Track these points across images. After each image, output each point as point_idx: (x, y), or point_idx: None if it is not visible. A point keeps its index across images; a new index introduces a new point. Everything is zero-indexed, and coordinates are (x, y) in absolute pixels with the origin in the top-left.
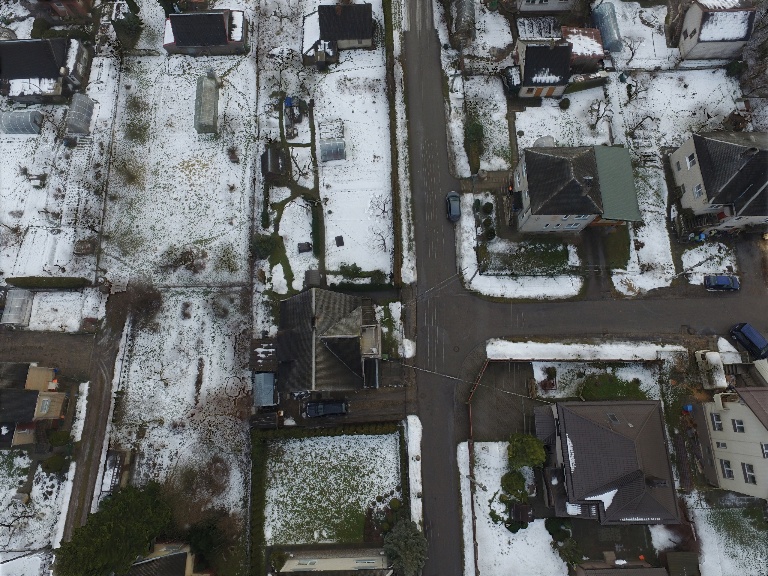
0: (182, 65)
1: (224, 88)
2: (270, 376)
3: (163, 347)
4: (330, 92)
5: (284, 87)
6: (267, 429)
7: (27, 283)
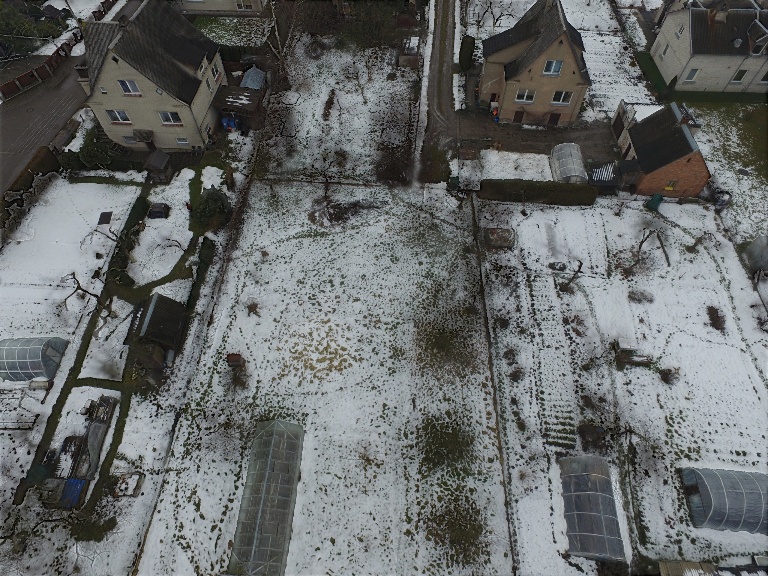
0: None
1: (224, 568)
2: None
3: None
4: None
5: (68, 555)
6: (253, 54)
7: (562, 183)
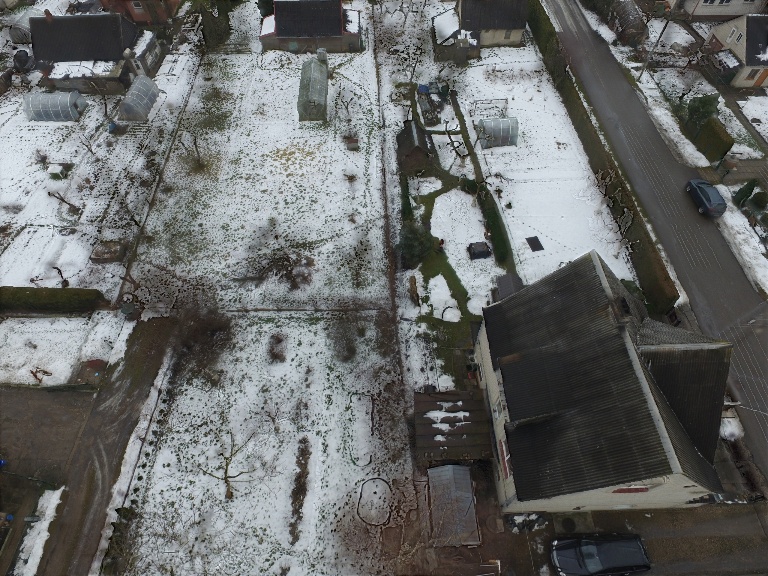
0: (280, 59)
1: (334, 79)
2: (463, 472)
3: (228, 416)
4: (476, 82)
5: (413, 79)
6: None
7: None
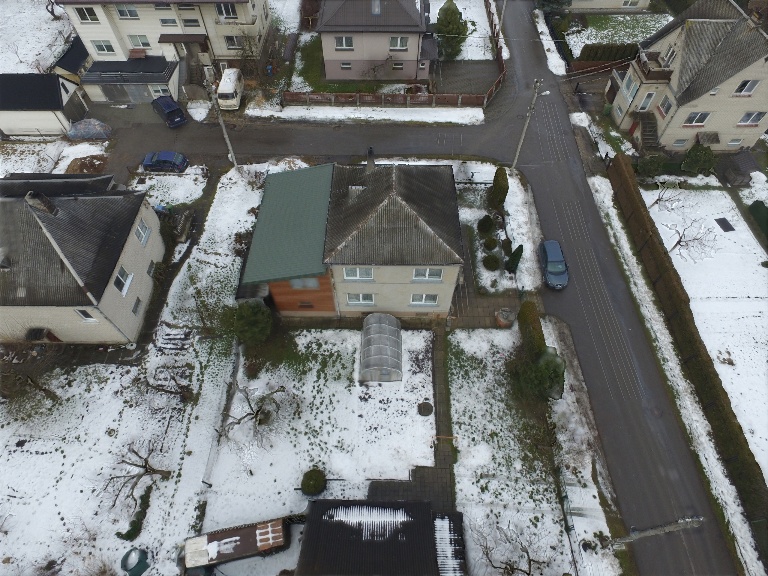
0: None
1: None
2: None
3: None
4: None
5: None
6: None
7: None
